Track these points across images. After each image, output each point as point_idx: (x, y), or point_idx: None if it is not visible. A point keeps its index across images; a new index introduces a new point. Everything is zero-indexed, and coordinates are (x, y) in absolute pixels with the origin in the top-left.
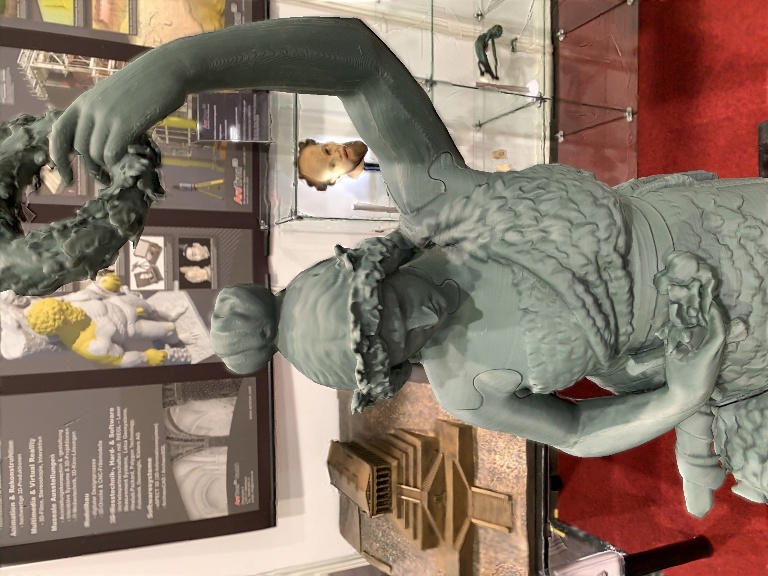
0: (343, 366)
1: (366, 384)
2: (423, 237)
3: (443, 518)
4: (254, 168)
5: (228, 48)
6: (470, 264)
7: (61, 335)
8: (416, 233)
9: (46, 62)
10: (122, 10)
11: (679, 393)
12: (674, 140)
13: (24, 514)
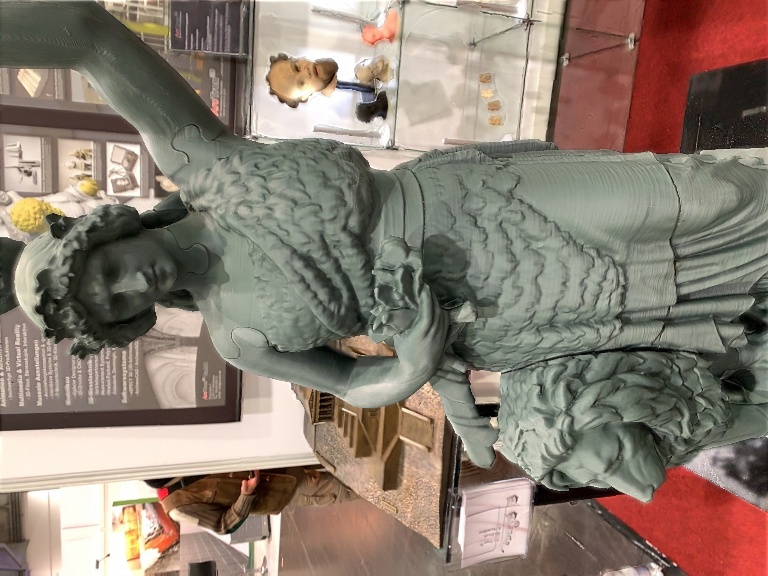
0: None
1: (55, 340)
2: (184, 201)
3: (376, 432)
4: (231, 79)
5: None
6: (219, 231)
7: None
8: (181, 196)
9: None
10: None
11: (404, 364)
12: (670, 74)
13: (12, 389)
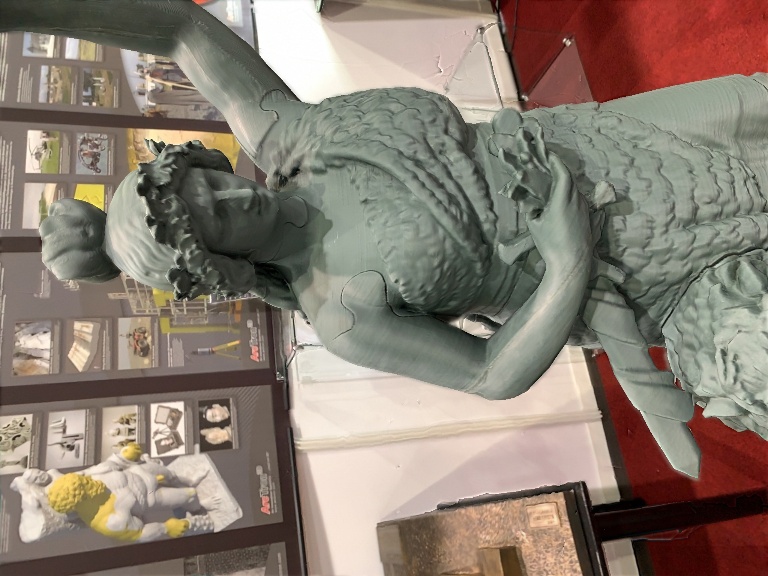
0: (144, 229)
1: (156, 229)
2: (273, 173)
3: None
4: (268, 326)
5: None
6: (315, 181)
7: (80, 511)
8: (270, 175)
9: None
10: None
11: (553, 259)
12: None
13: None
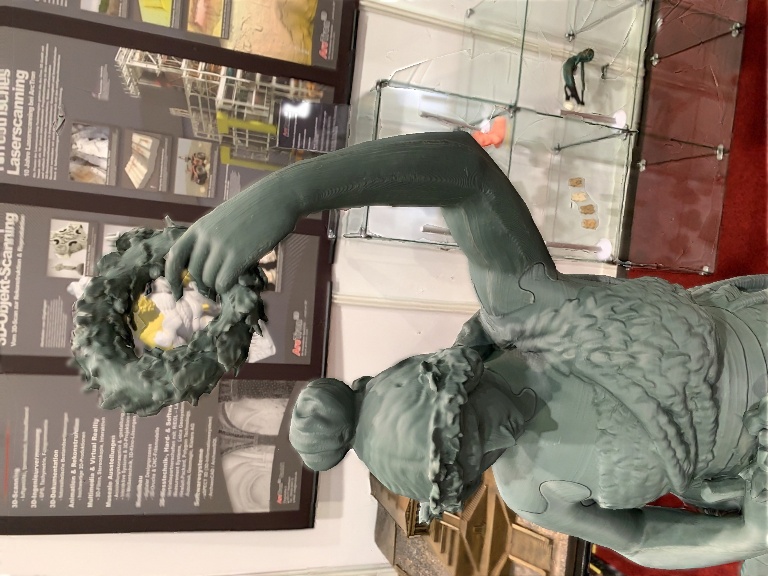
0: (417, 485)
1: (439, 511)
2: (505, 339)
3: (480, 549)
4: None
5: (340, 178)
6: (550, 374)
7: None
8: (498, 333)
9: (141, 61)
10: (216, 14)
11: (756, 532)
12: (767, 186)
13: (83, 488)
